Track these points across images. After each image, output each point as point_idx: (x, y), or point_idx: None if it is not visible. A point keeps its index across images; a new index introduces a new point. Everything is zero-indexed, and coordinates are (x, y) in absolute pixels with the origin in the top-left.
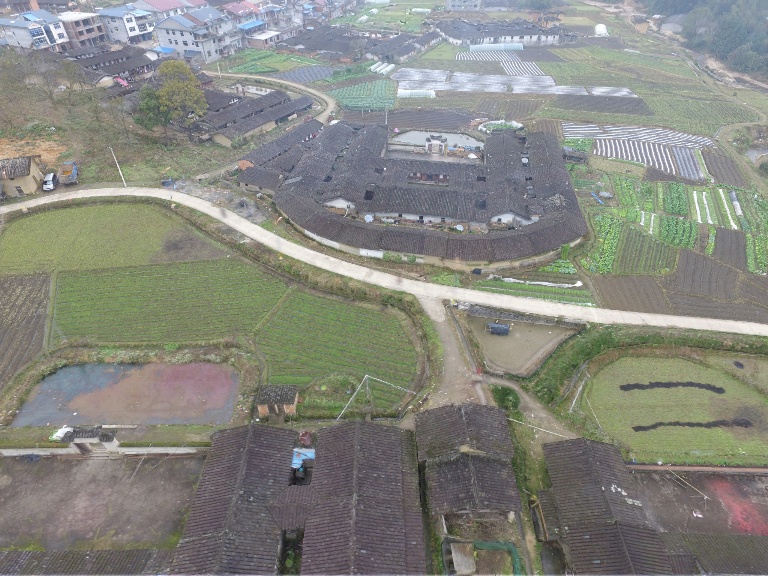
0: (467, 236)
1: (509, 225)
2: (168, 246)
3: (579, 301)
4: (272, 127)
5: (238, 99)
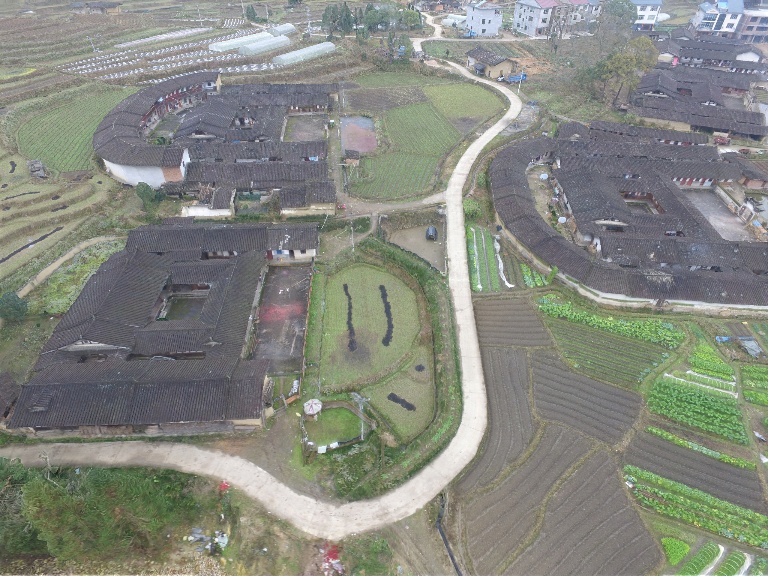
0: (530, 208)
1: (596, 254)
2: (465, 118)
3: (482, 280)
4: (685, 129)
5: (717, 104)
